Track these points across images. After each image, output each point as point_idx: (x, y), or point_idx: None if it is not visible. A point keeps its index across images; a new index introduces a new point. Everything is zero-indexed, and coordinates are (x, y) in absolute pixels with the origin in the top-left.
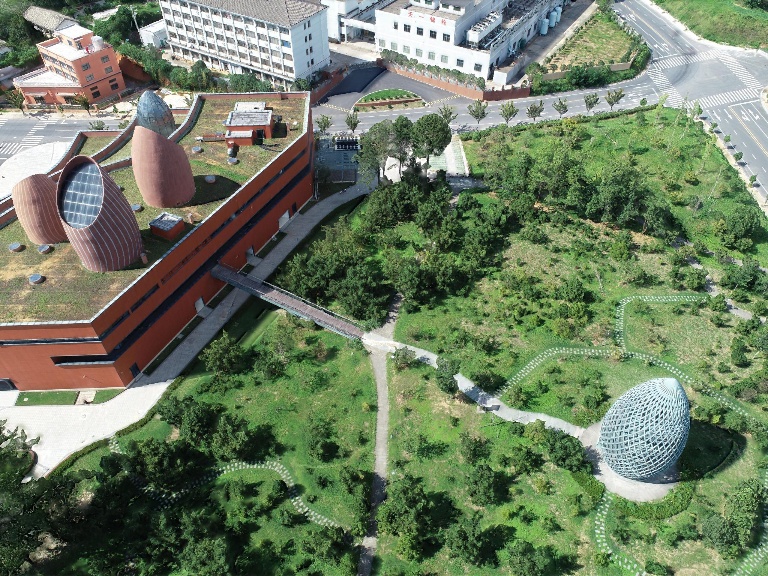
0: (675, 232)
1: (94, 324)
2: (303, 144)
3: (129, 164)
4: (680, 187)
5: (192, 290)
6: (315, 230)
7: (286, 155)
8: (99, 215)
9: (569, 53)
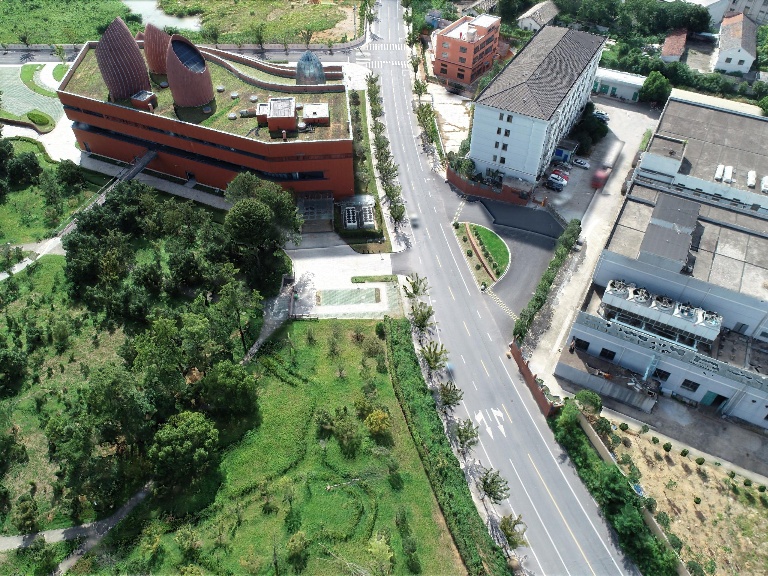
0: (69, 511)
1: (59, 94)
2: (264, 151)
3: (240, 77)
4: (185, 565)
5: (132, 146)
6: (220, 210)
7: (238, 141)
8: (95, 50)
9: (744, 501)
